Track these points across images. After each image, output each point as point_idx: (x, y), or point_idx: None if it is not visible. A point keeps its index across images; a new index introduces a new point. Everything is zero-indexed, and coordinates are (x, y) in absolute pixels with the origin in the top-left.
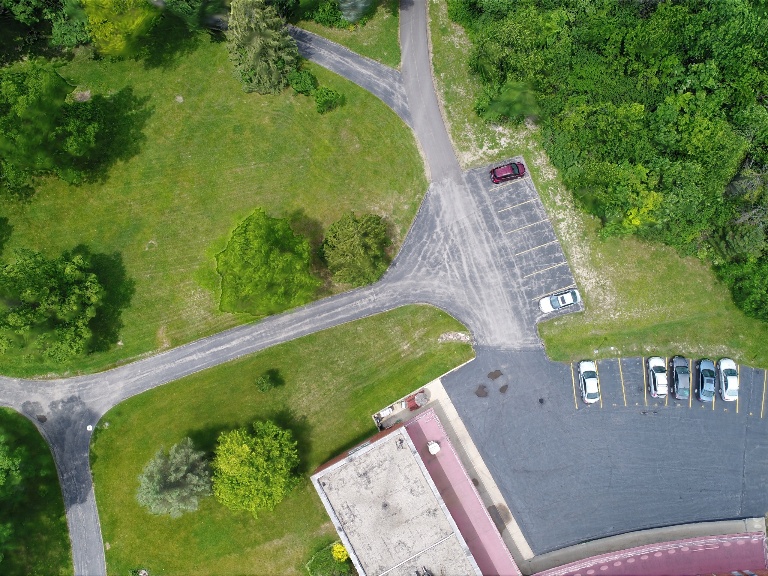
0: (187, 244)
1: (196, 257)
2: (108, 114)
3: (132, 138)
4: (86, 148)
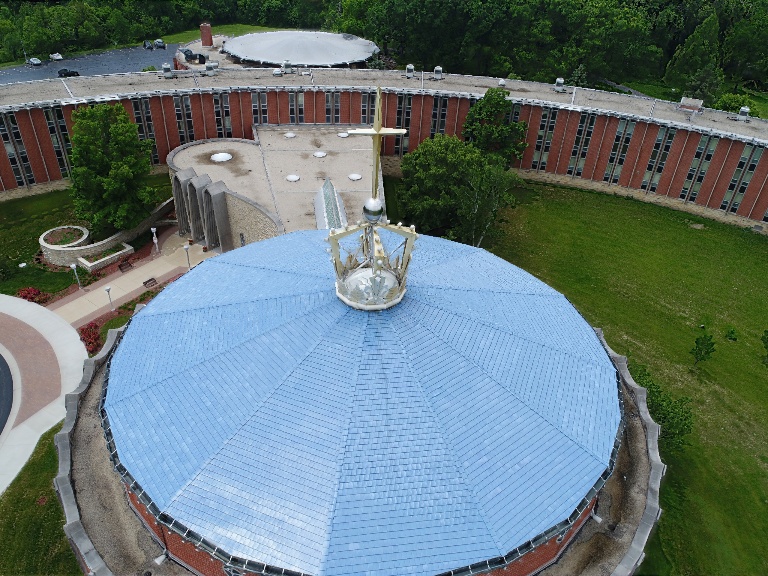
0: (760, 114)
1: (761, 116)
2: (760, 98)
3: (765, 102)
4: (761, 69)
